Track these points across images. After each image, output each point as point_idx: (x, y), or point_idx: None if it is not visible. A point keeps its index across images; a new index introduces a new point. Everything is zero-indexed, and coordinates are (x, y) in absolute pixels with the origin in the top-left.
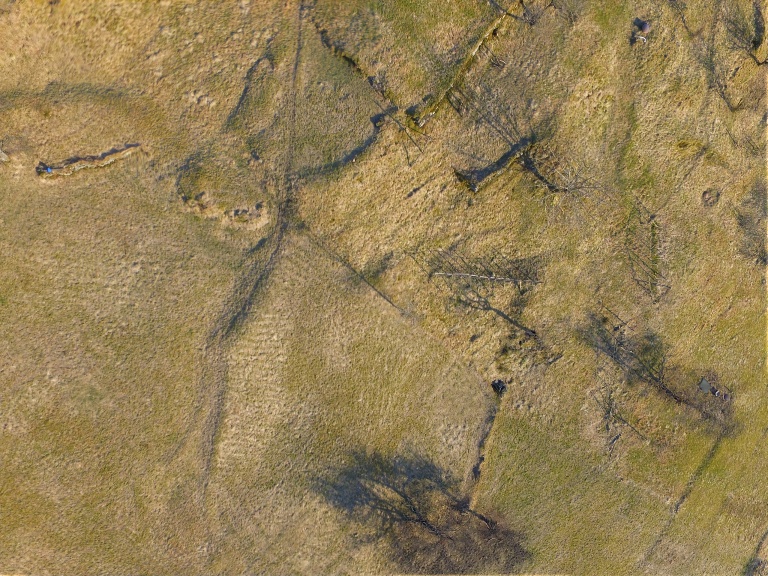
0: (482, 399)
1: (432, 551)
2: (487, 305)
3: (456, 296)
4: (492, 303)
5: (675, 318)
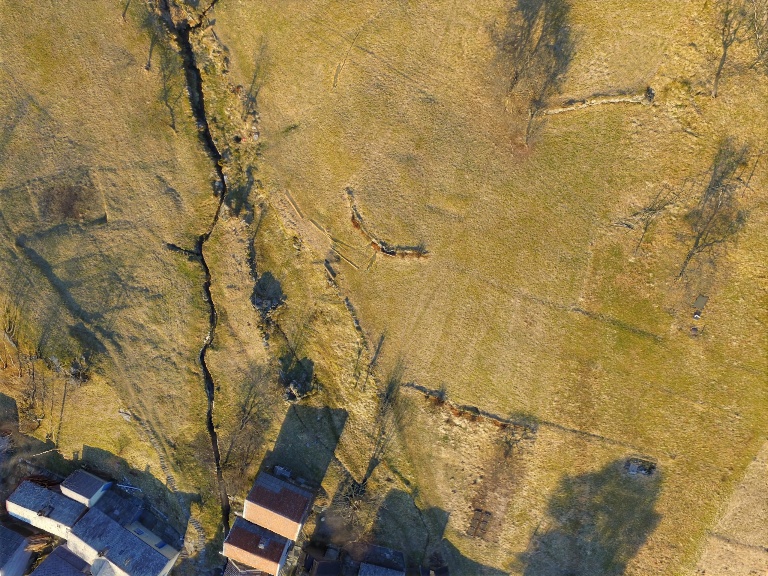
0: (638, 79)
1: (491, 99)
2: (729, 43)
3: (731, 8)
4: (732, 47)
5: (767, 236)
